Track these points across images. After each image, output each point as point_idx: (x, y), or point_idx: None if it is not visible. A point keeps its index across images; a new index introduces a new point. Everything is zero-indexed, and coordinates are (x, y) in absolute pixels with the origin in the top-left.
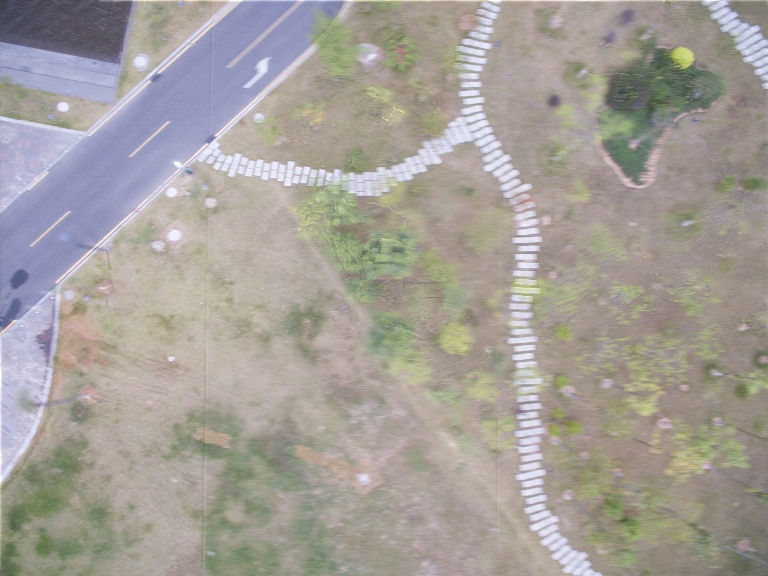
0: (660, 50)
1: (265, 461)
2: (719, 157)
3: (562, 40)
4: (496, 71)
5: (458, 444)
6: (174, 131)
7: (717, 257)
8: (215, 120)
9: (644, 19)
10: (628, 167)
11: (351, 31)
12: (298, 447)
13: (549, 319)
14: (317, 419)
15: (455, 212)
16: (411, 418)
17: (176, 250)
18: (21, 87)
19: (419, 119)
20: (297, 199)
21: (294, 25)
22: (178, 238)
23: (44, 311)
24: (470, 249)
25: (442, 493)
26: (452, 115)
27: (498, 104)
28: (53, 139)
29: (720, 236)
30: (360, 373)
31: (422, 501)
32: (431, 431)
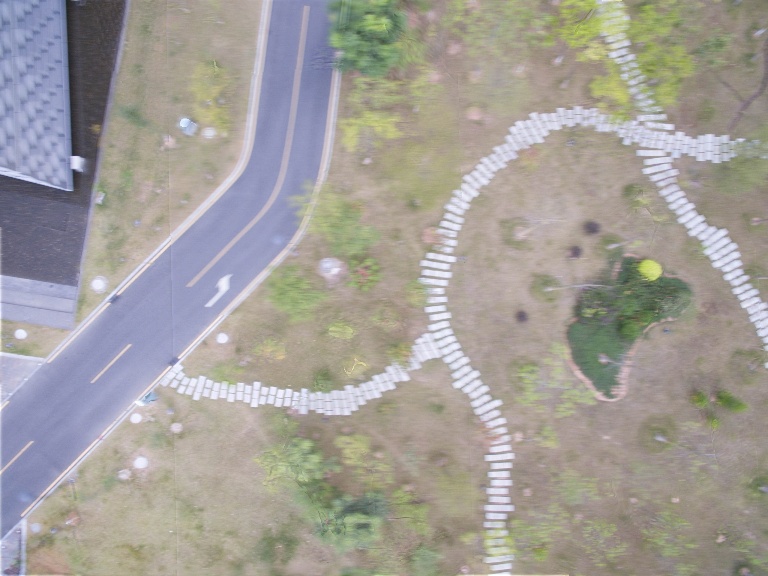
0: (627, 260)
1: None
2: (690, 367)
3: (528, 251)
4: (462, 285)
5: None
6: (136, 355)
7: None
8: (177, 342)
9: (610, 230)
10: (599, 381)
11: (313, 246)
12: None
13: (524, 539)
14: None
15: (425, 429)
16: None
17: (143, 478)
18: None
19: (386, 335)
20: (264, 420)
21: (255, 240)
22: (144, 466)
23: (10, 545)
24: (442, 467)
25: None
26: (419, 331)
27: (465, 319)
28: (12, 367)
29: (691, 473)
30: None
31: None
32: None
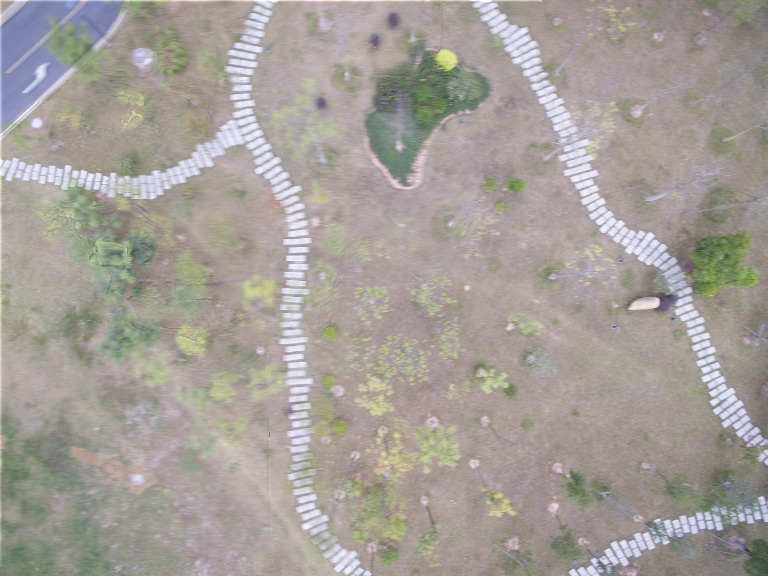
0: (427, 52)
1: (40, 462)
2: (486, 158)
3: (332, 43)
4: (267, 74)
5: (232, 444)
6: None
7: (476, 257)
8: None
9: (410, 22)
10: (395, 169)
11: (127, 36)
12: (73, 448)
13: (316, 320)
14: (92, 420)
15: (228, 214)
16: (185, 418)
17: None
18: None
19: (193, 123)
20: None
21: (73, 30)
22: None
23: None
24: (242, 251)
25: (215, 493)
26: (224, 118)
27: (269, 107)
28: None
29: (461, 237)
30: (134, 374)
31: (195, 501)
32: (204, 431)
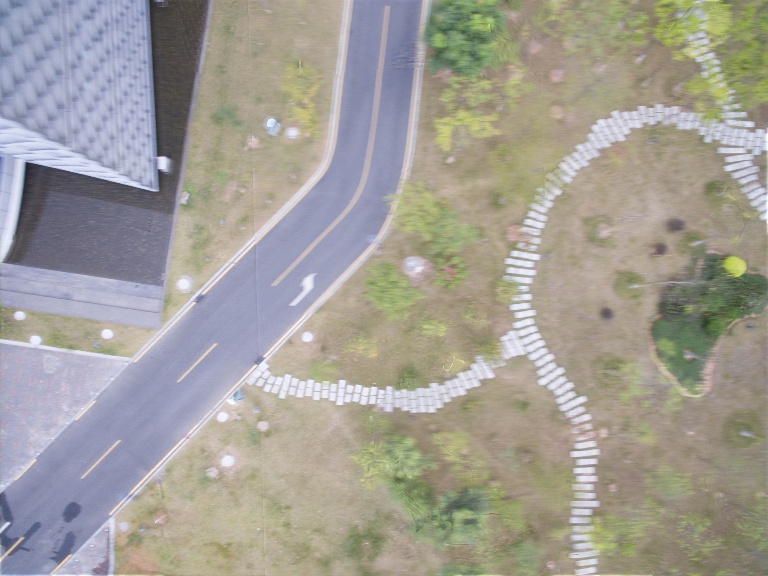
0: (711, 256)
1: None
2: None
3: (612, 249)
4: (546, 282)
5: None
6: (222, 354)
7: None
8: (263, 341)
9: (694, 227)
10: (684, 377)
11: (397, 245)
12: None
13: (610, 534)
14: None
15: (510, 426)
16: None
17: (230, 476)
18: (63, 316)
19: (470, 333)
20: (350, 418)
21: (338, 239)
22: (231, 464)
23: (98, 544)
24: (527, 464)
25: None
26: (504, 329)
27: (550, 316)
28: (98, 367)
29: None
30: None
31: None
32: None
